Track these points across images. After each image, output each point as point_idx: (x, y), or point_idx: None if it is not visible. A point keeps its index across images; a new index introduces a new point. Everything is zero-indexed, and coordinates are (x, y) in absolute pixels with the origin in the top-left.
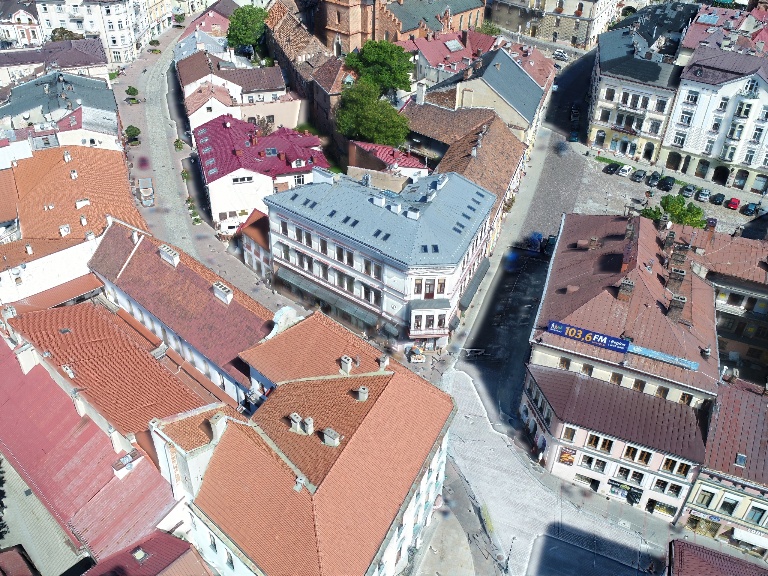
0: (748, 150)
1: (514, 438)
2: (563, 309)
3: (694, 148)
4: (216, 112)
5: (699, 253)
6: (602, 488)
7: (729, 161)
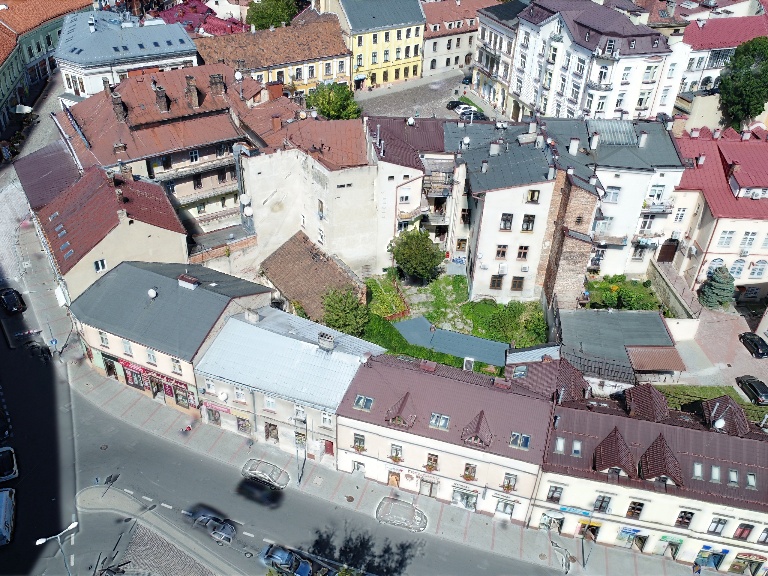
0: (557, 103)
1: None
2: None
3: (526, 97)
4: (222, 6)
5: (247, 105)
6: None
7: (542, 114)
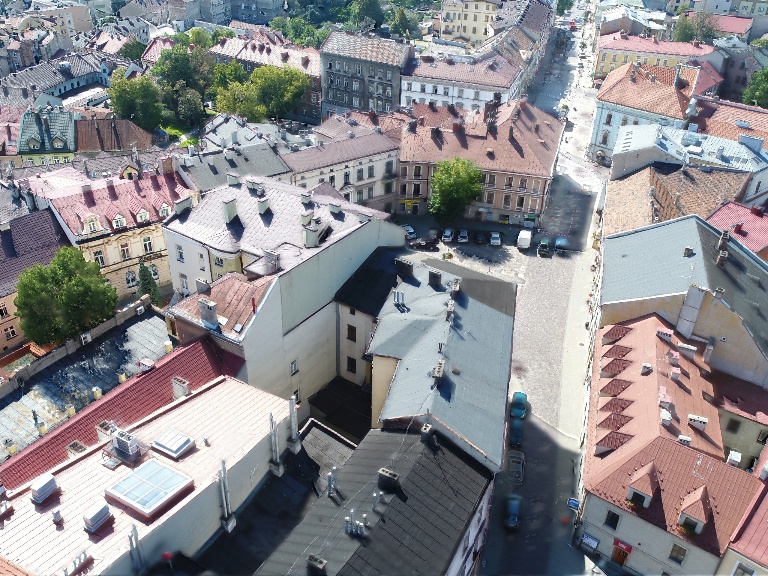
0: None
1: None
2: None
3: None
4: None
5: None
6: None
7: None
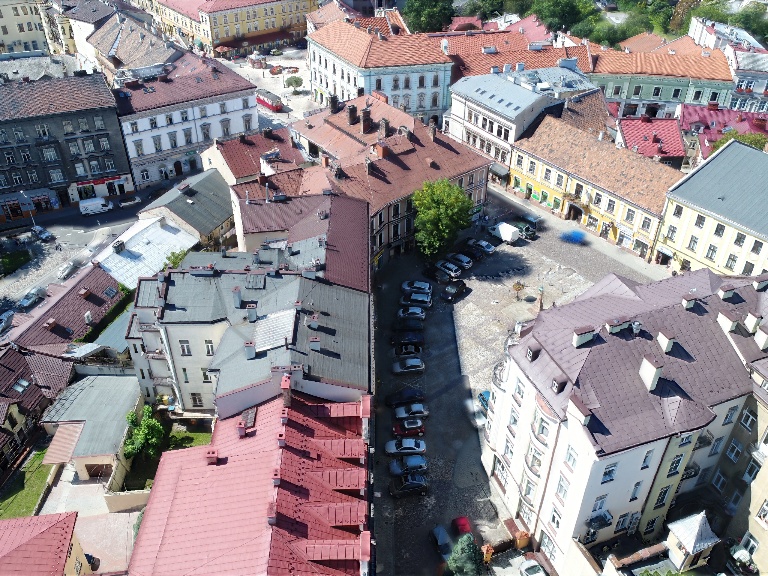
0: None
1: None
2: None
3: None
4: None
5: None
6: None
7: None
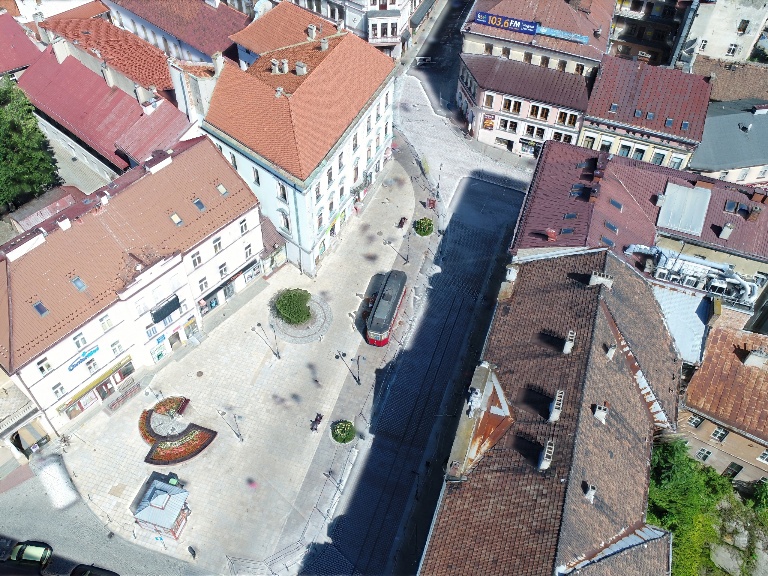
0: None
1: (451, 118)
2: (489, 5)
3: None
4: None
5: None
6: (515, 147)
7: None
